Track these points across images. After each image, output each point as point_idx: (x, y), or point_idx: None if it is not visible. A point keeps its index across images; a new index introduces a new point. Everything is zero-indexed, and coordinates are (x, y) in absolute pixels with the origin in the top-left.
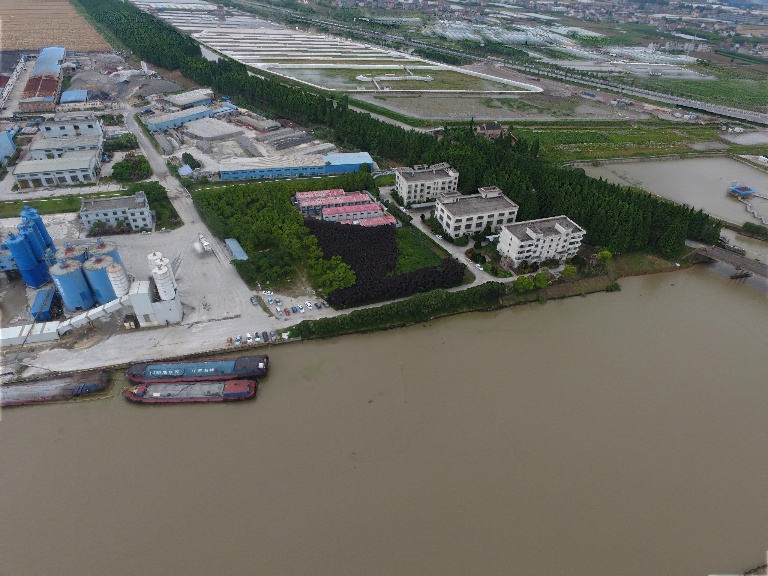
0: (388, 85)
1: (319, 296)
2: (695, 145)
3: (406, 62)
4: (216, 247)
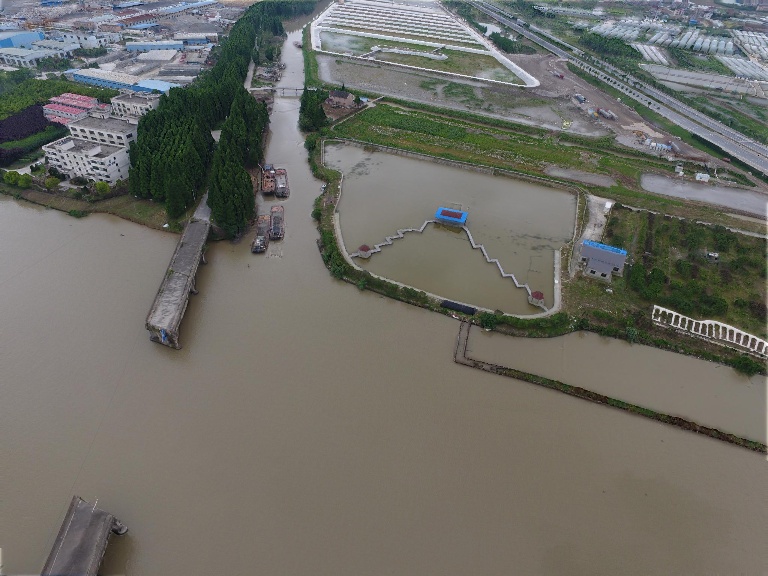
0: (384, 56)
1: None
2: (561, 170)
3: (463, 43)
4: None
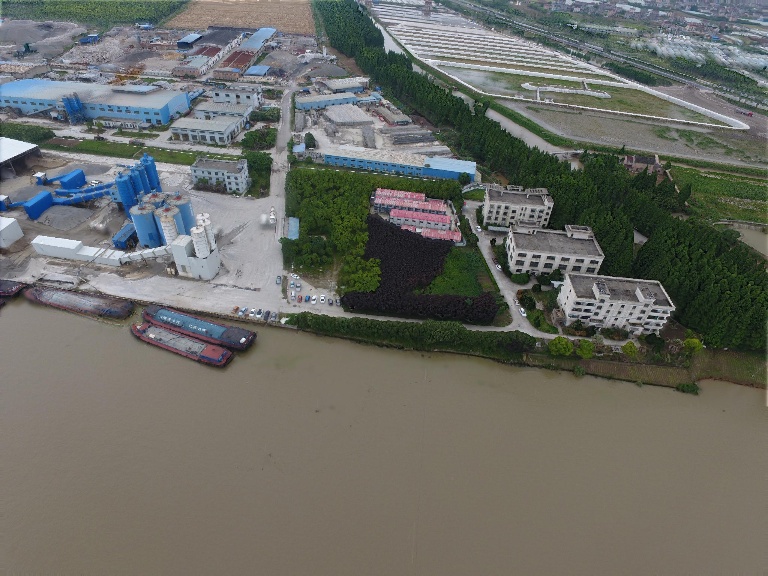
0: (552, 97)
1: (338, 293)
2: None
3: (589, 75)
4: (280, 222)
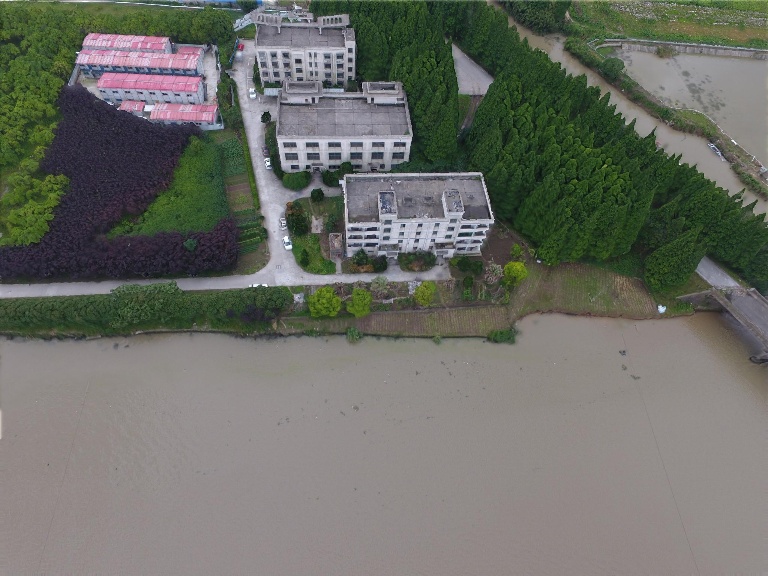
0: None
1: None
2: None
3: None
4: None
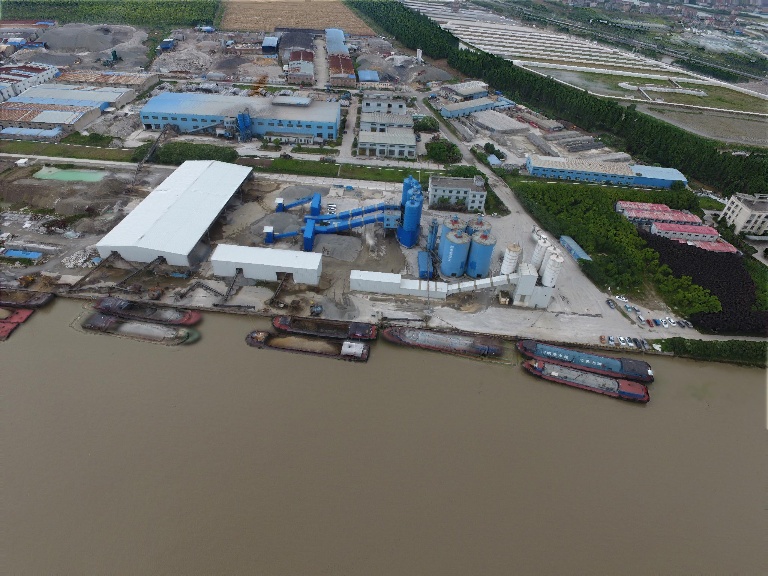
0: (657, 96)
1: (677, 314)
2: None
3: (667, 73)
4: (551, 241)
